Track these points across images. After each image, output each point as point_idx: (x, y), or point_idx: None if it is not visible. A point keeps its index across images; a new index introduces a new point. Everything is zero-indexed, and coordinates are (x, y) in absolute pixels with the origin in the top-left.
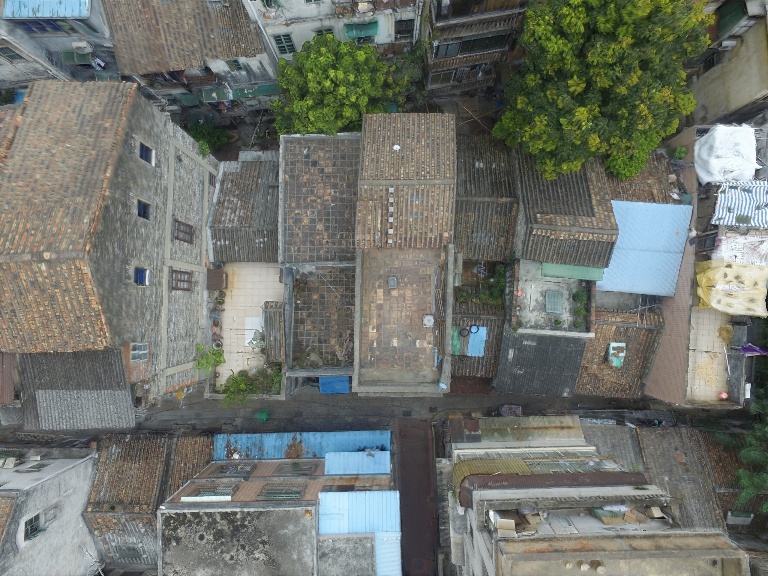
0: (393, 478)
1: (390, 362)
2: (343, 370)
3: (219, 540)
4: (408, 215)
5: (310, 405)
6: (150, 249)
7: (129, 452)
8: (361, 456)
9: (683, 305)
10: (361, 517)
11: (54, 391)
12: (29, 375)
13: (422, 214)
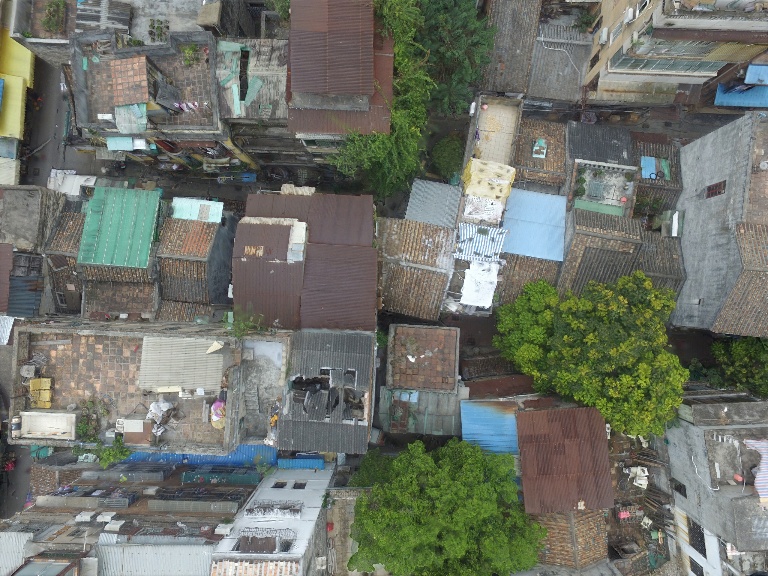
0: (728, 65)
1: None
2: None
3: None
4: None
5: None
6: None
7: None
8: None
9: None
10: None
11: None
12: None
13: (763, 248)
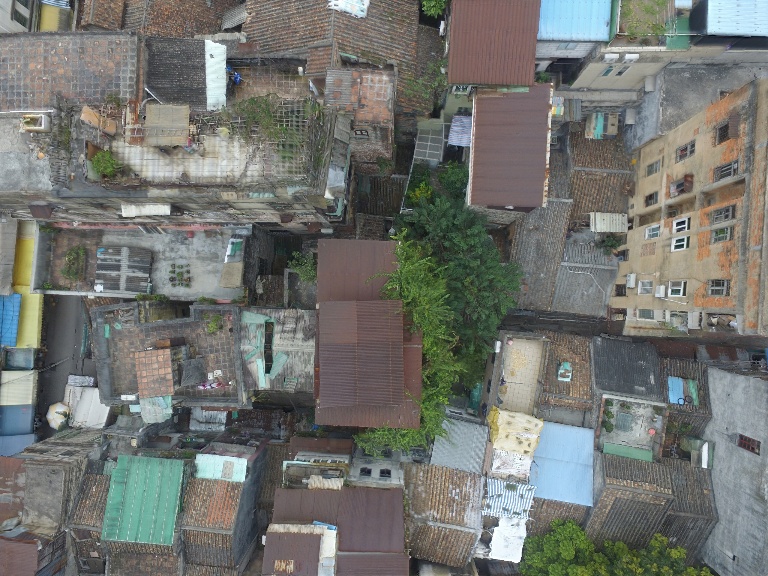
0: None
1: None
2: None
3: None
4: None
5: None
6: None
7: None
8: None
9: None
10: None
11: None
12: None
13: None
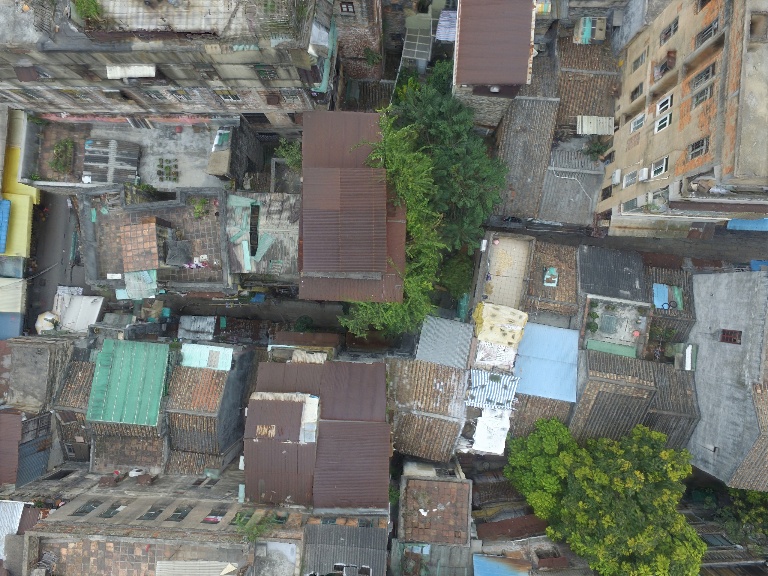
0: None
1: None
2: None
3: None
4: None
5: (761, 249)
6: None
7: None
8: None
9: None
10: None
11: None
12: None
13: None
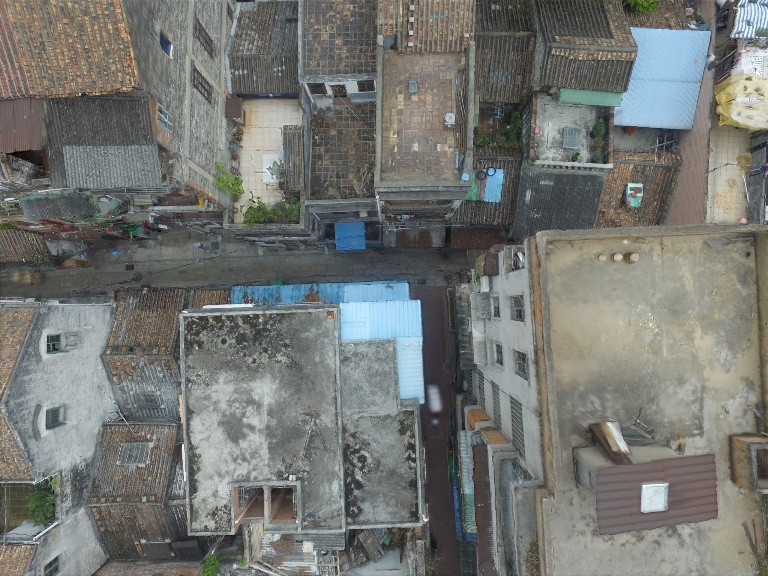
0: None
1: (411, 166)
2: (362, 198)
3: (241, 344)
4: (429, 15)
5: None
6: (174, 24)
7: (147, 302)
8: (380, 288)
9: (702, 132)
10: (383, 324)
11: (81, 147)
12: (56, 129)
13: (443, 14)
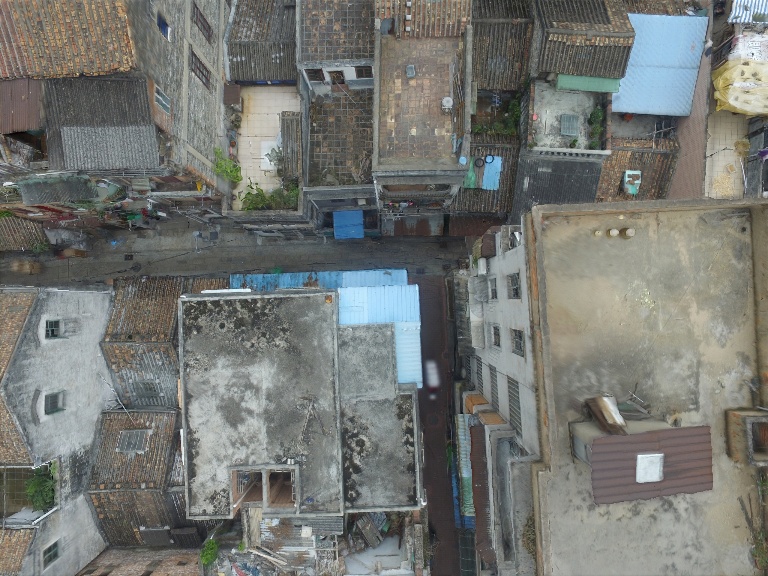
0: None
1: (409, 151)
2: None
3: (240, 328)
4: None
5: None
6: (172, 7)
7: (145, 291)
8: (378, 274)
9: (699, 118)
10: (381, 309)
11: (79, 128)
12: (54, 110)
13: None
